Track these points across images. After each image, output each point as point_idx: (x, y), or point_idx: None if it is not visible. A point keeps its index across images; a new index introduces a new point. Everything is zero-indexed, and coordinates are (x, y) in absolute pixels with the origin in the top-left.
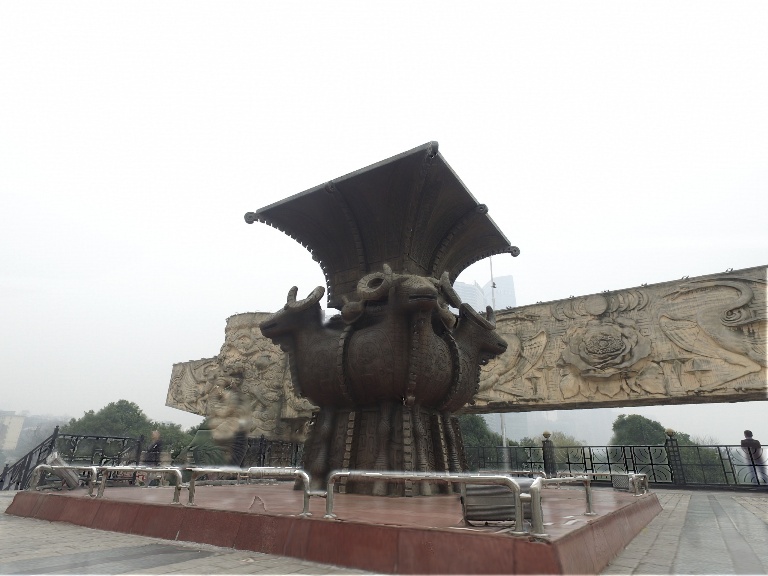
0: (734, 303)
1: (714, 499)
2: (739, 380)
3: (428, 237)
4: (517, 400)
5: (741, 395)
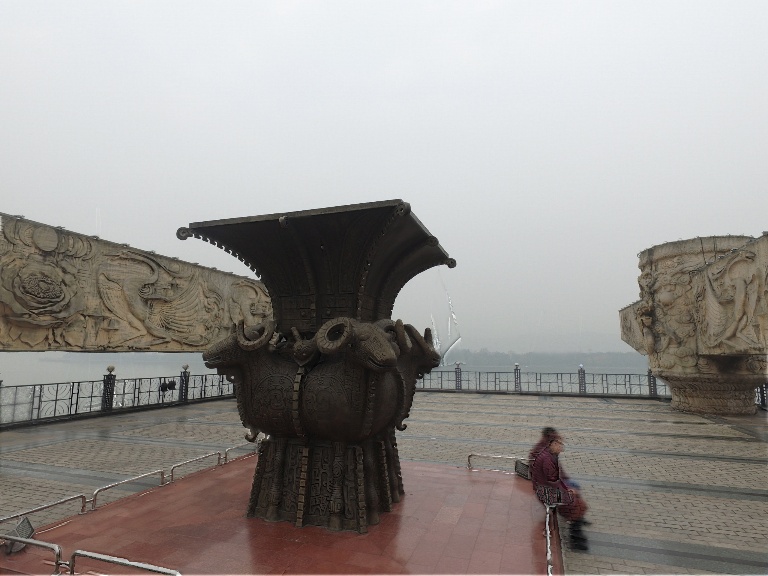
0: (149, 280)
1: None
2: (133, 340)
3: None
4: None
5: (126, 351)
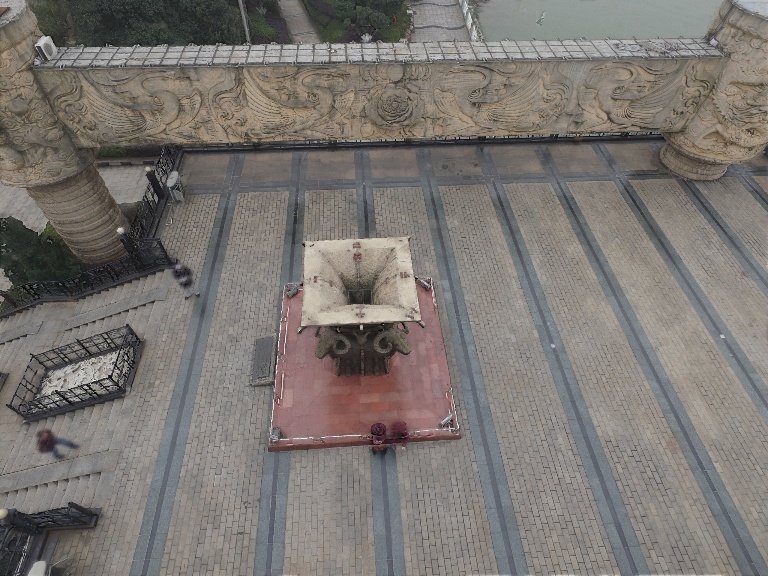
0: (479, 86)
1: (437, 215)
2: (462, 130)
3: None
4: (329, 138)
5: None
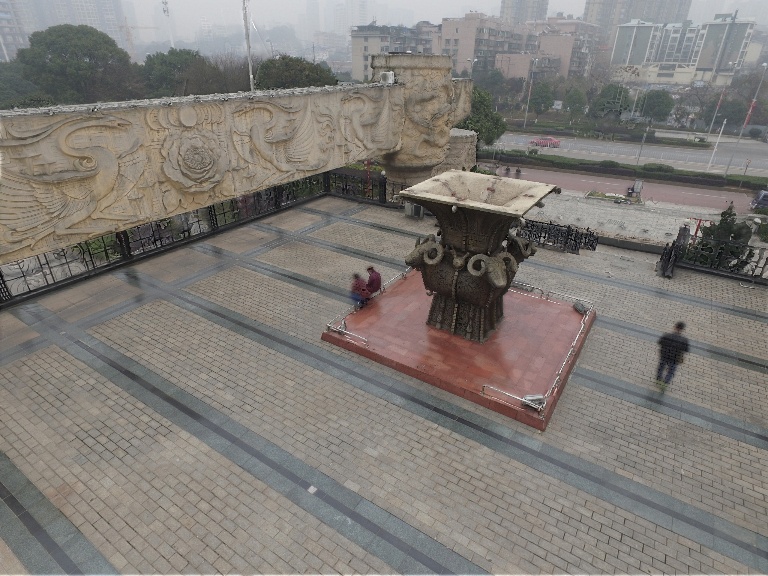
0: None
1: None
2: None
3: (453, 216)
4: None
5: None
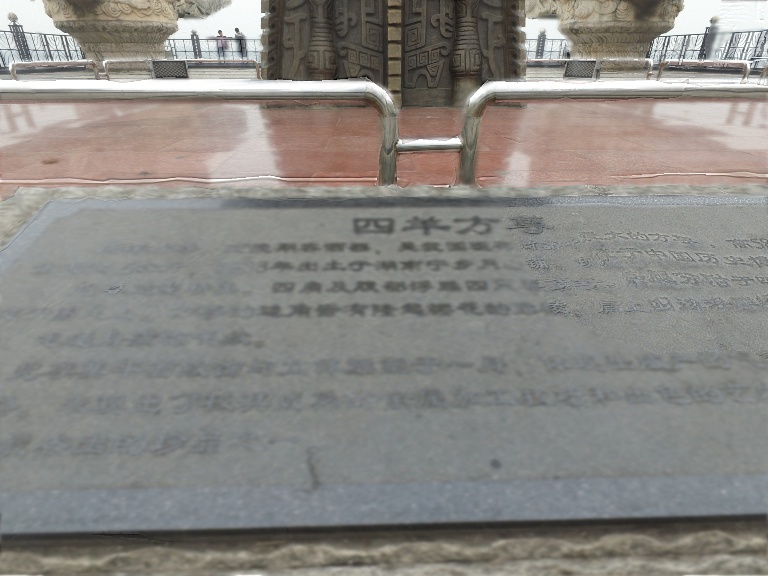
0: None
1: None
2: None
3: None
4: None
5: None
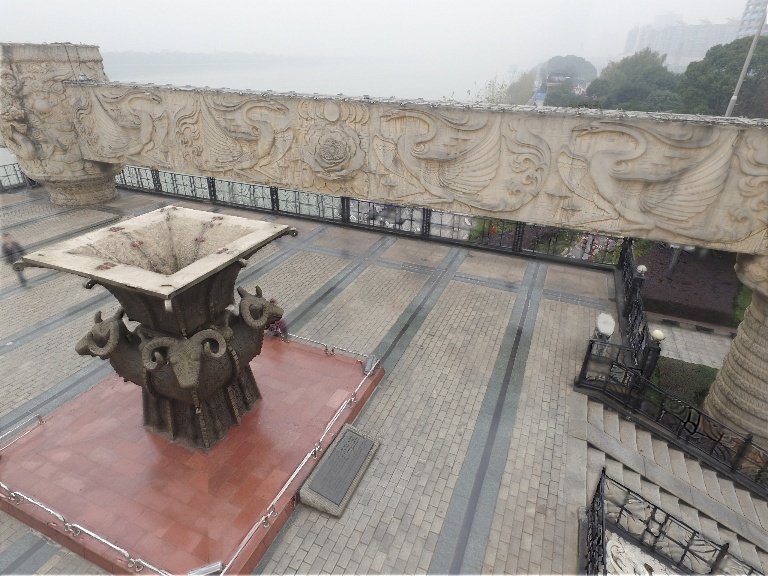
0: None
1: None
2: None
3: None
4: None
5: None
